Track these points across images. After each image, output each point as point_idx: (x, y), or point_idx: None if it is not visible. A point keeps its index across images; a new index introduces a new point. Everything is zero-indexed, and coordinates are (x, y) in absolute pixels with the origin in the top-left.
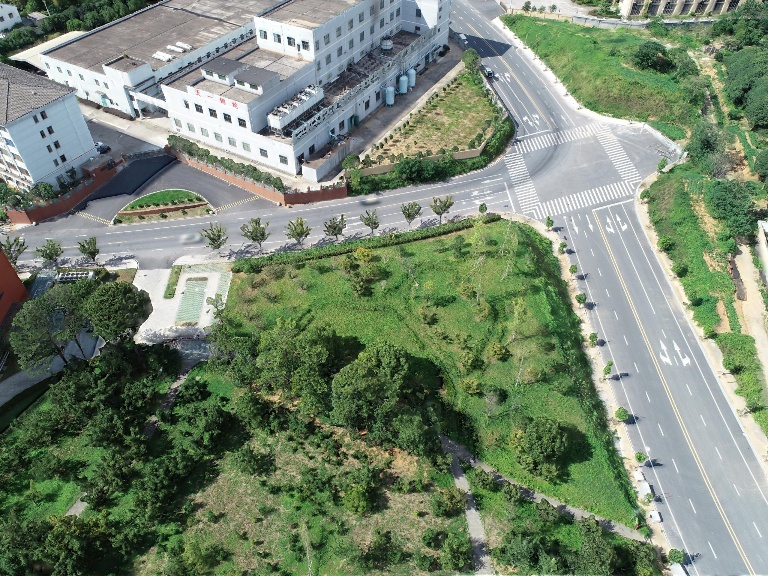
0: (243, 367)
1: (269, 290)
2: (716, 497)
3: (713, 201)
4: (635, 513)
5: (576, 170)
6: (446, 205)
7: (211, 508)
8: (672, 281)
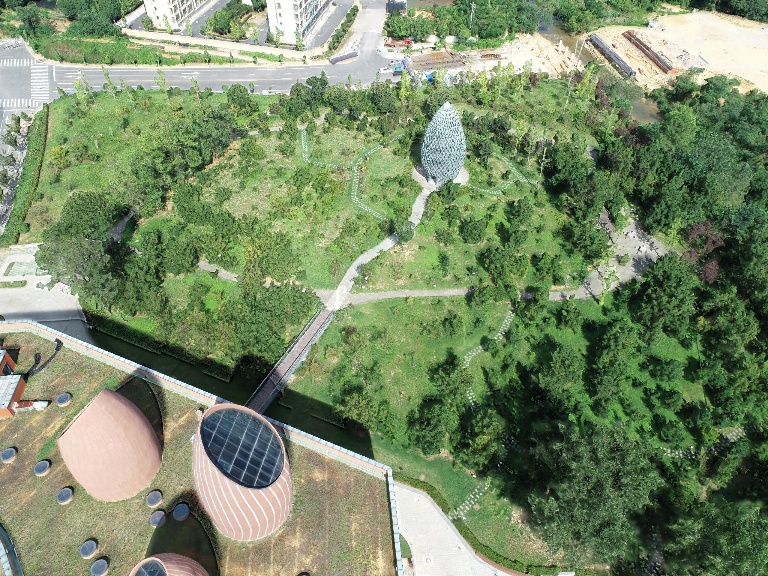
0: (157, 181)
1: (57, 215)
2: (272, 79)
3: (88, 30)
4: (277, 94)
5: (2, 80)
6: (17, 121)
7: (247, 212)
8: (137, 66)
